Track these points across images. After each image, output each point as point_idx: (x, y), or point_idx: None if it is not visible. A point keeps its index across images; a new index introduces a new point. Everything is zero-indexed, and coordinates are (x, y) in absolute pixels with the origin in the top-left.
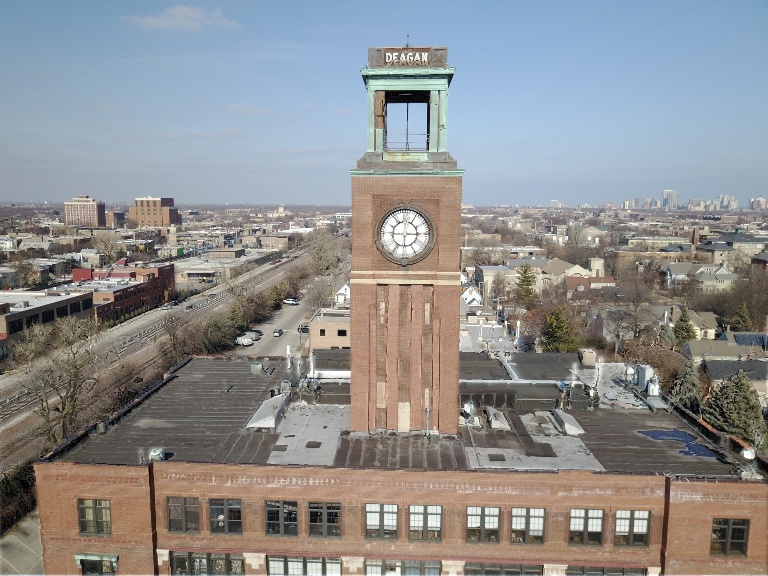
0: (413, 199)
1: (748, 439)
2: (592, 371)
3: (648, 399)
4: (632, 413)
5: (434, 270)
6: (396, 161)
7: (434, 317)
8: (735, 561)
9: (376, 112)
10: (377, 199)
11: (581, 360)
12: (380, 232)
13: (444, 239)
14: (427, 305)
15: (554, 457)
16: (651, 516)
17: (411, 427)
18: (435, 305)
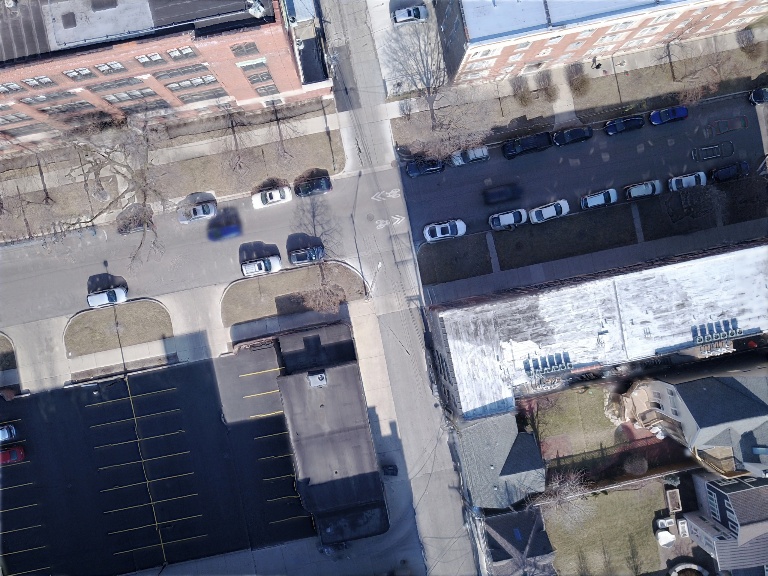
0: None
1: None
2: None
3: None
4: None
5: None
6: None
7: None
8: (252, 55)
9: None
10: None
11: None
12: None
13: None
14: None
15: (114, 8)
16: None
17: None
18: None
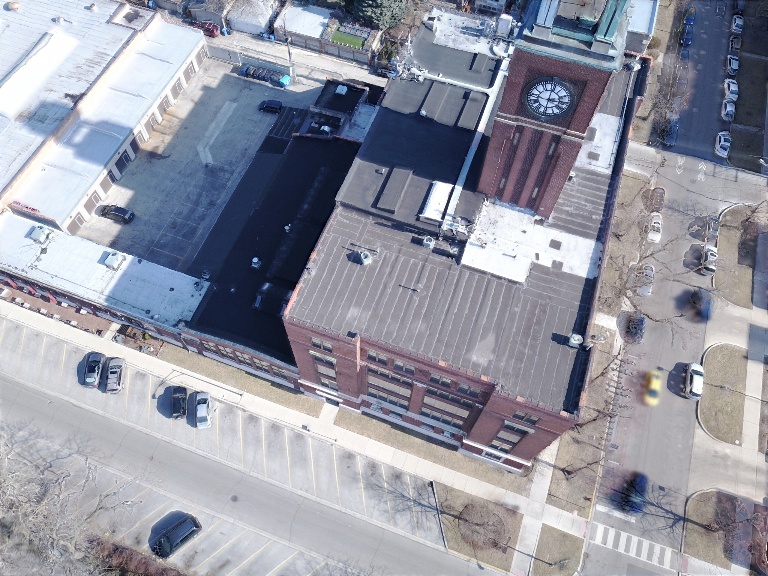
0: None
1: None
2: (440, 33)
3: None
4: None
5: None
6: None
7: None
8: None
9: None
10: None
11: (432, 29)
12: None
13: None
14: None
15: (597, 130)
16: None
17: None
18: None
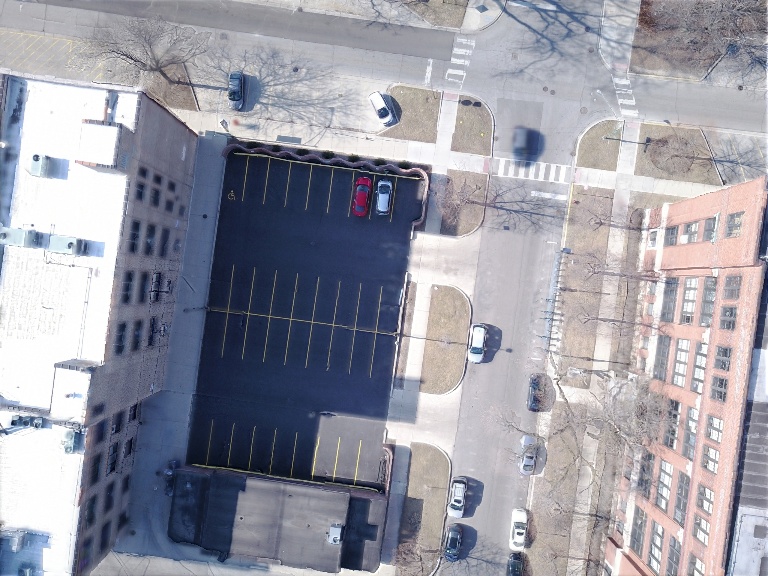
0: None
1: None
2: None
3: None
4: None
5: None
6: None
7: None
8: None
9: None
10: None
11: None
12: None
13: None
14: None
15: None
16: None
17: None
18: None
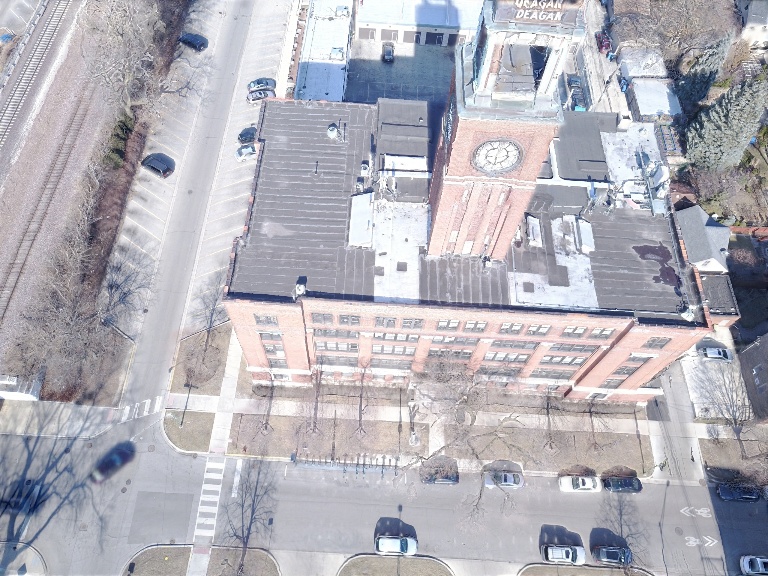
0: (511, 133)
1: (736, 140)
2: (623, 135)
3: (654, 201)
4: (636, 217)
5: (515, 178)
6: (503, 101)
7: (506, 204)
8: (653, 349)
9: (494, 59)
10: (479, 132)
11: (618, 124)
12: (476, 154)
13: (530, 160)
14: (502, 194)
15: (567, 287)
16: (615, 331)
17: (471, 253)
18: (509, 199)
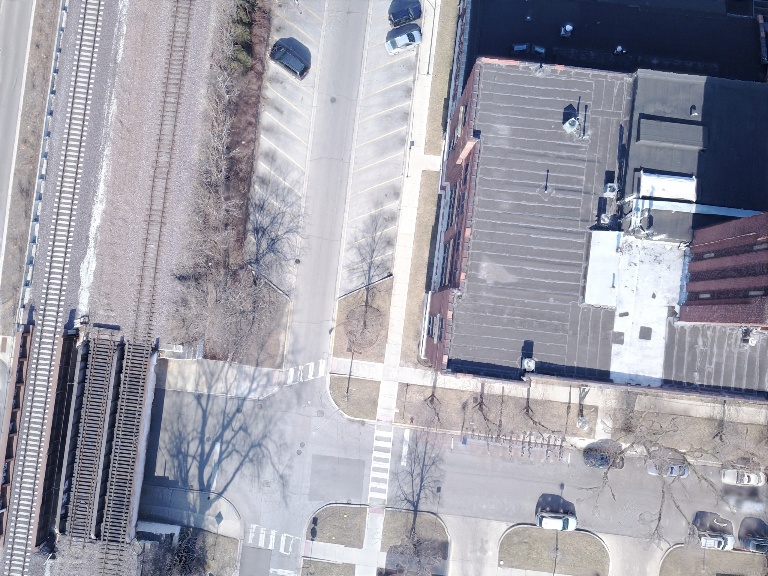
0: None
1: None
2: None
3: None
4: None
5: None
6: None
7: None
8: None
9: None
10: None
11: None
12: None
13: None
14: None
15: None
16: None
17: None
18: None
